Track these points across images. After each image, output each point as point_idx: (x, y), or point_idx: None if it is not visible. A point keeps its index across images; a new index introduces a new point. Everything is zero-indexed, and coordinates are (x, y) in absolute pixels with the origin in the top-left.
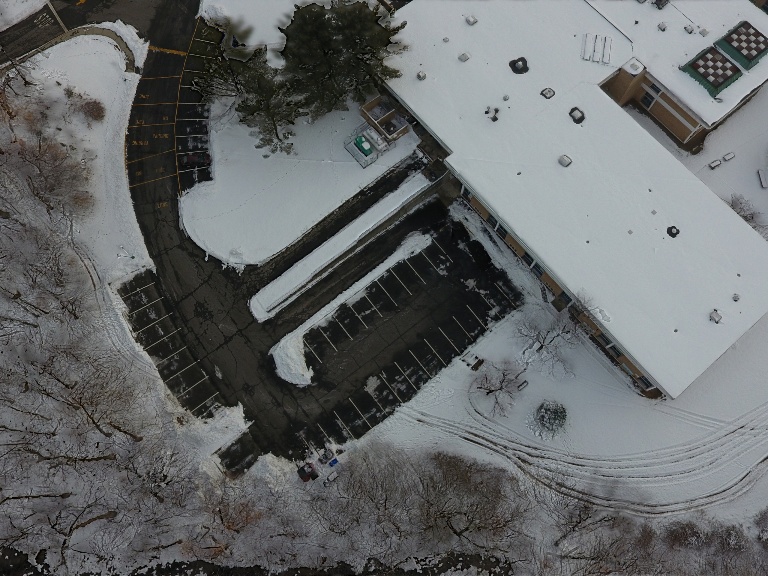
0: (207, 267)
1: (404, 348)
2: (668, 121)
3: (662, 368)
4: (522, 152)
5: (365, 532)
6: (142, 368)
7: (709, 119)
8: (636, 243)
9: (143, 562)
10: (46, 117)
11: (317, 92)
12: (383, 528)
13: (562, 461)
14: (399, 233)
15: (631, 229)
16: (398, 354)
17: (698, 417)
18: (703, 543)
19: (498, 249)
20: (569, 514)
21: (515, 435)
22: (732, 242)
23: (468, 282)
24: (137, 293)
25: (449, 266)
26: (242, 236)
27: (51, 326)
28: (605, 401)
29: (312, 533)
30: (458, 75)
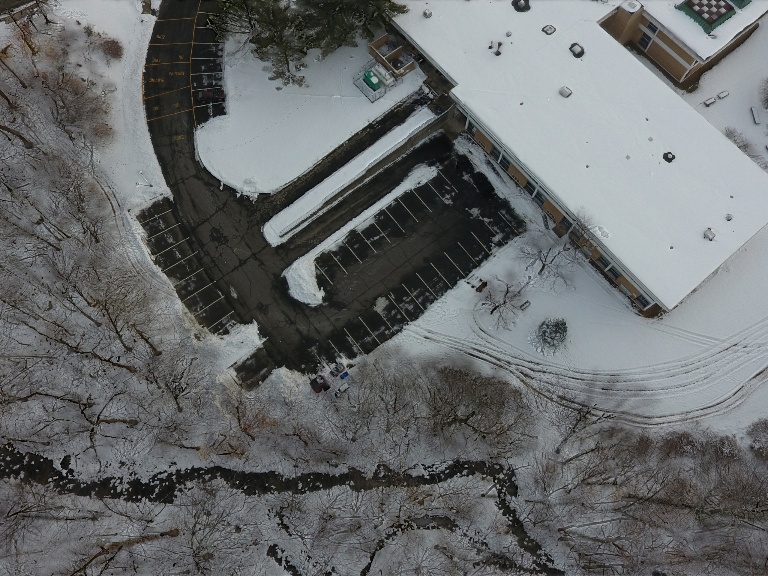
0: (222, 195)
1: (411, 271)
2: (665, 61)
3: (658, 281)
4: (524, 84)
5: (375, 440)
6: (161, 288)
7: (704, 54)
8: (634, 167)
9: (163, 467)
10: (67, 54)
11: (328, 27)
12: (392, 436)
13: (563, 375)
14: (406, 165)
15: (629, 155)
16: (406, 277)
17: (693, 335)
18: (698, 451)
19: (501, 180)
20: (570, 421)
21: (518, 351)
22: (725, 167)
23: (472, 211)
24: (155, 219)
25: (454, 196)
26: (255, 167)
27: (73, 249)
28: (604, 320)
29: (324, 439)
30: (463, 13)
